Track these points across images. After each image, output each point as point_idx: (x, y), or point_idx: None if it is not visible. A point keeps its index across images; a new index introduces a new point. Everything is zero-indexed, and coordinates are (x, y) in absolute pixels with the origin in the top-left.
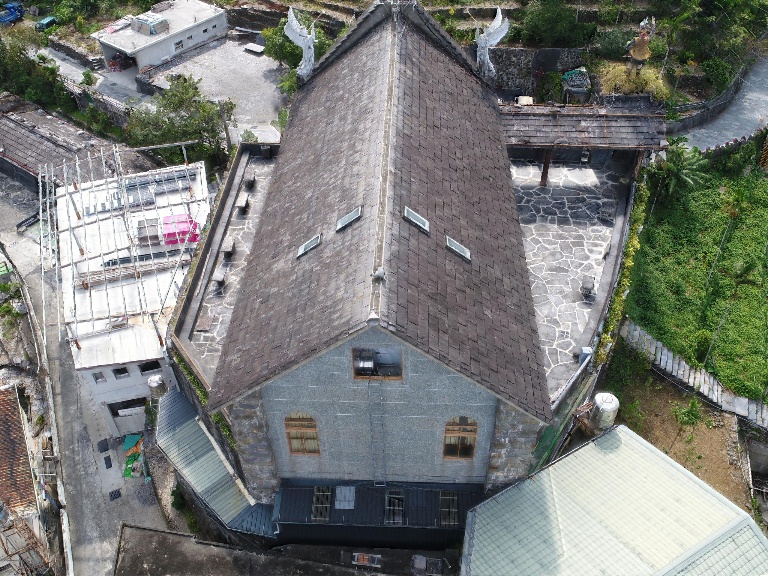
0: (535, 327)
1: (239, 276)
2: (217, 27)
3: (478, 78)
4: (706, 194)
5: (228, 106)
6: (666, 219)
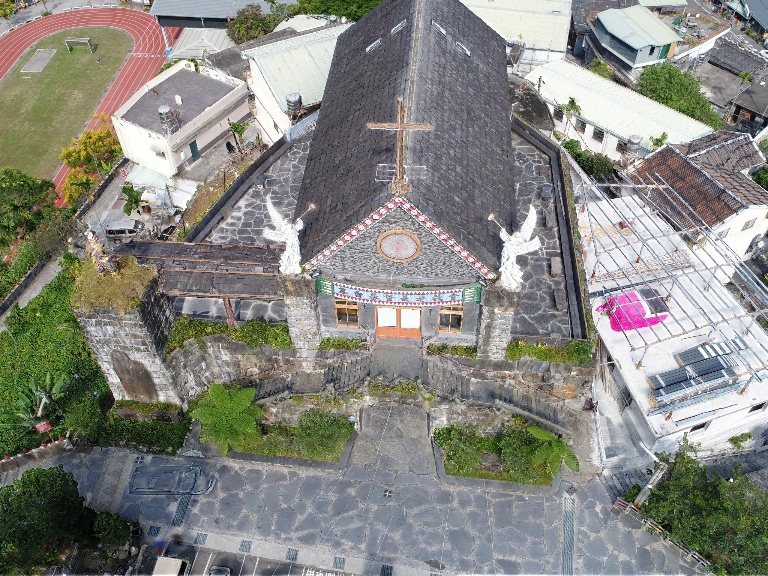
0: None
1: (533, 204)
2: None
3: None
4: (2, 442)
5: (657, 490)
6: None
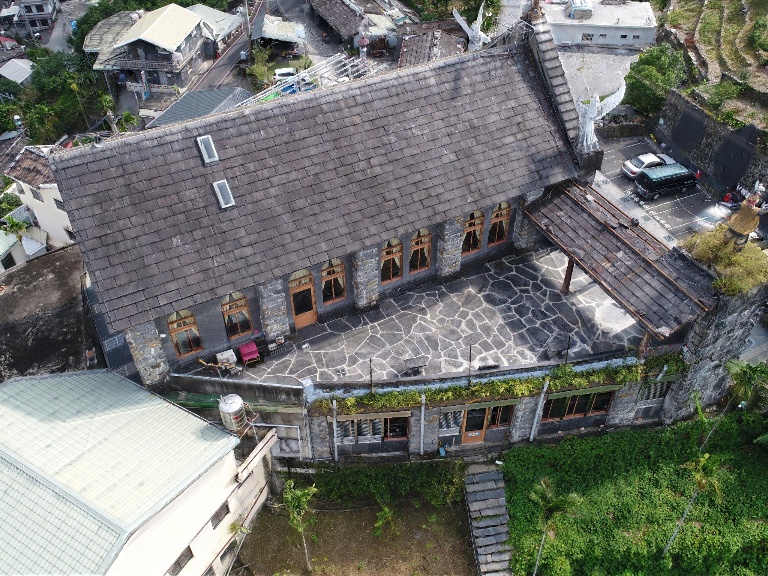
0: (220, 293)
1: None
2: (640, 38)
3: (570, 146)
4: None
5: None
6: (740, 469)
